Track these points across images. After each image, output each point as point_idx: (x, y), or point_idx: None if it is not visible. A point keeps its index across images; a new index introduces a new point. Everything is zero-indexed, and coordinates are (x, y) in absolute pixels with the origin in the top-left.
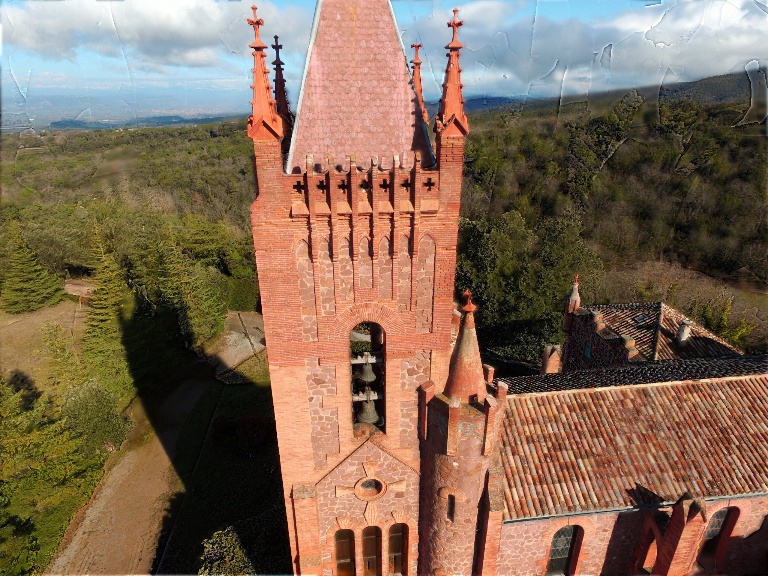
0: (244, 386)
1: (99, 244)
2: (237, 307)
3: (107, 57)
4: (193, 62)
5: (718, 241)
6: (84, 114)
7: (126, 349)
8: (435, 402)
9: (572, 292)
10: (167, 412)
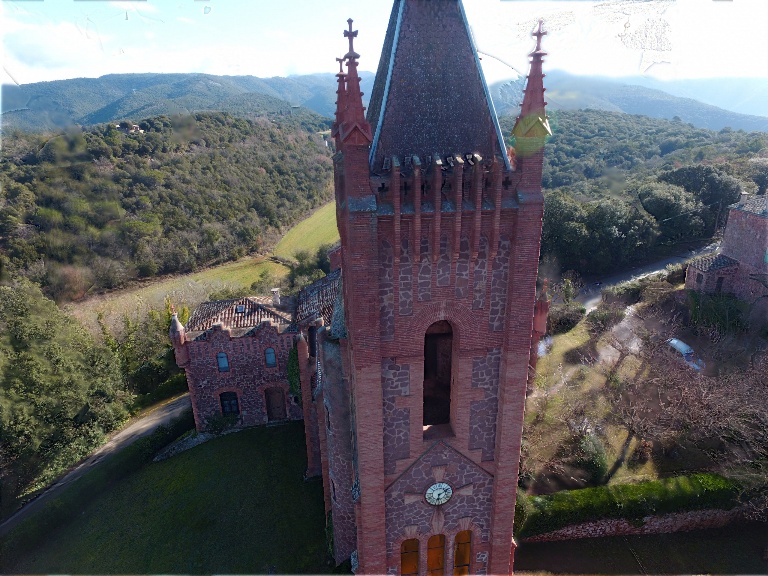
0: None
1: None
2: None
3: None
4: None
5: (67, 270)
6: None
7: None
8: None
9: (176, 323)
10: None
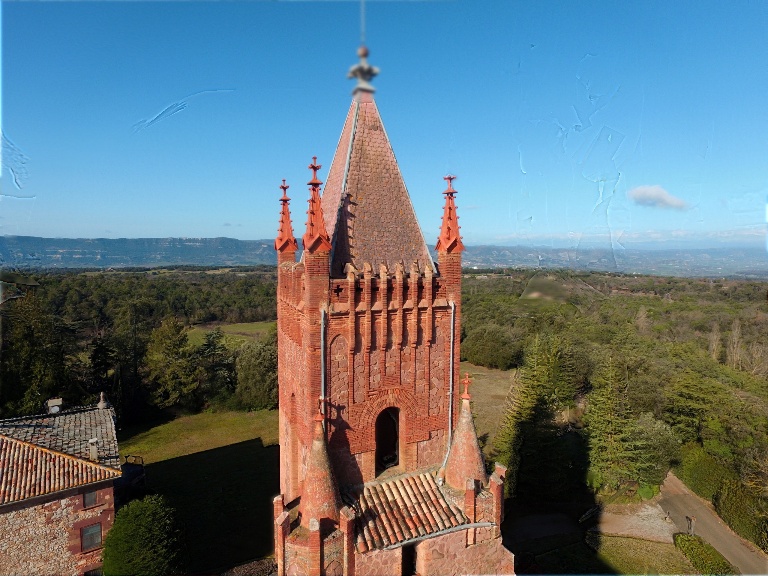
0: (594, 555)
1: (535, 355)
2: (692, 486)
3: (617, 210)
4: (746, 207)
5: None
6: (562, 254)
7: (519, 450)
8: (296, 499)
9: None
10: (520, 525)
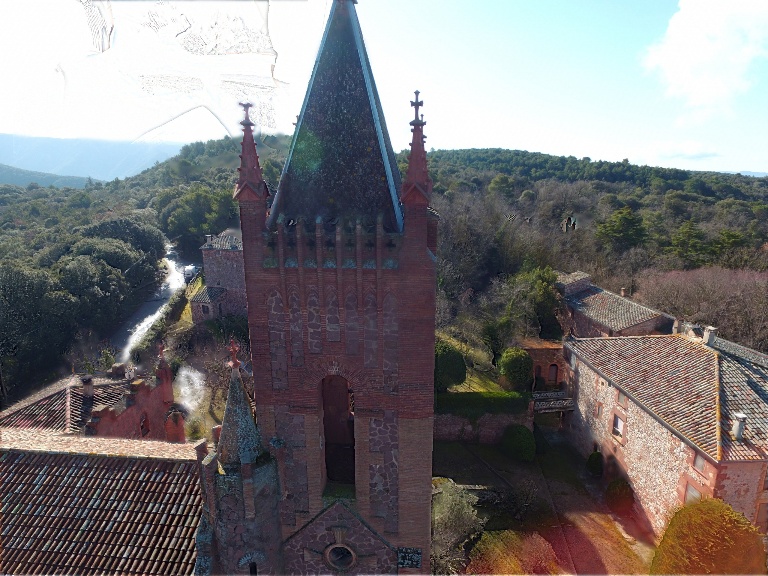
0: None
1: None
2: None
3: None
4: None
5: None
6: None
7: None
8: None
9: None
10: None
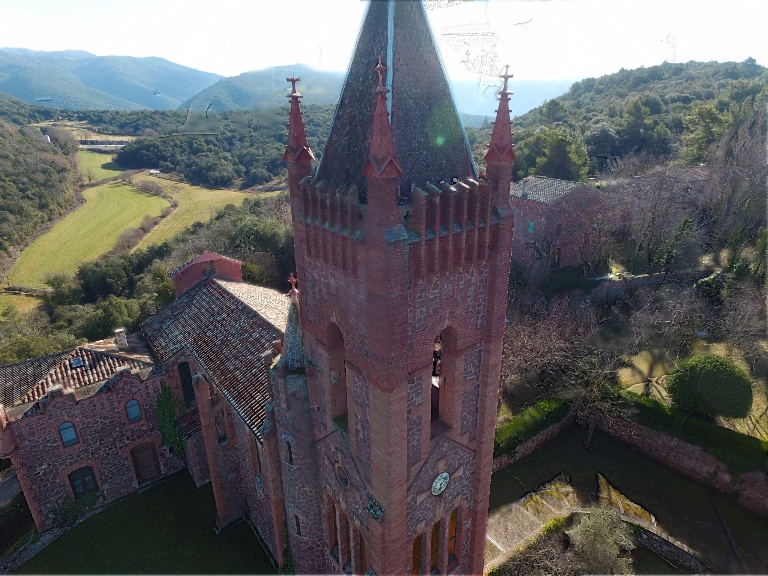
0: None
1: None
2: None
3: None
4: None
5: None
6: None
7: None
8: None
9: None
10: None
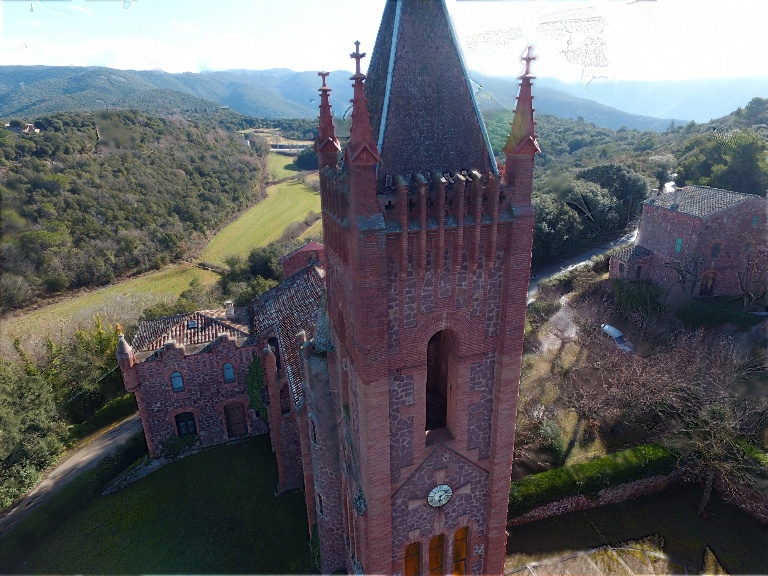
0: None
1: None
2: None
3: None
4: None
5: None
6: None
7: None
8: None
9: (124, 345)
10: None
